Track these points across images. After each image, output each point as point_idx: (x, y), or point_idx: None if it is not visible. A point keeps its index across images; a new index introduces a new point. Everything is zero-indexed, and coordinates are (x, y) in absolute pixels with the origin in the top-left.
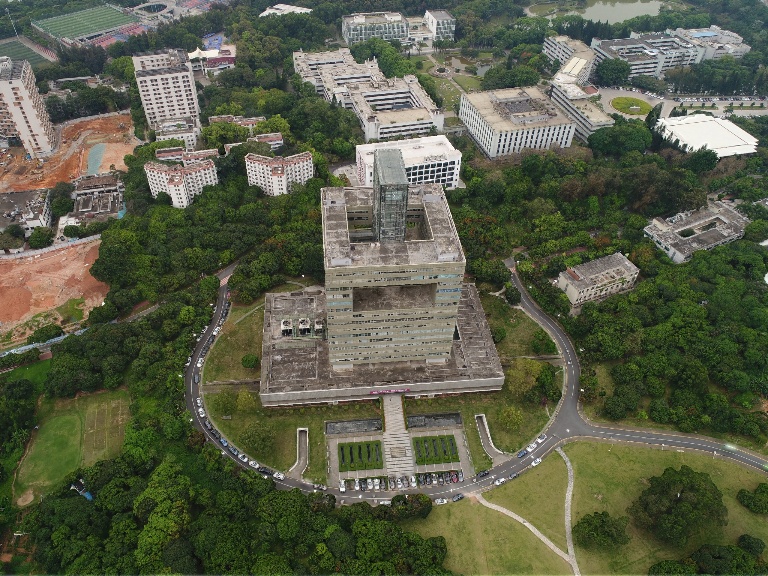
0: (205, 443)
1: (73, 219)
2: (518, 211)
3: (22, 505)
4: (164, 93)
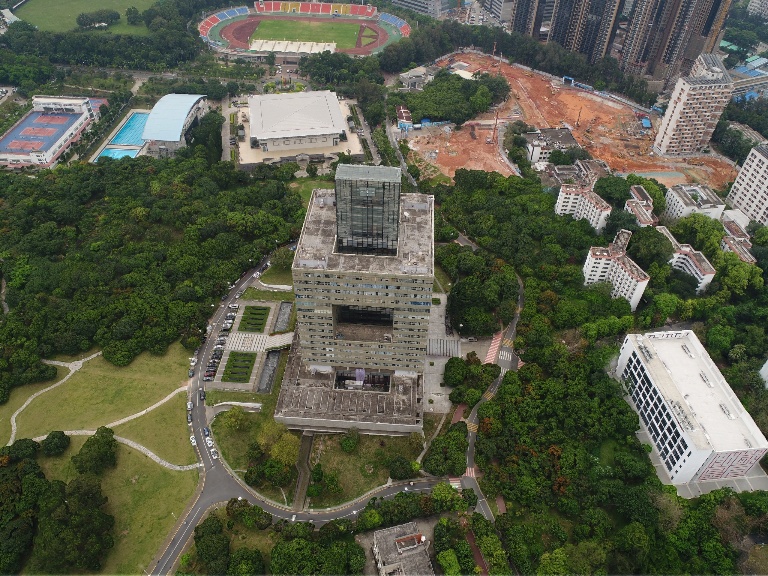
0: (296, 240)
1: (545, 167)
2: (588, 532)
3: (290, 185)
4: (759, 180)
